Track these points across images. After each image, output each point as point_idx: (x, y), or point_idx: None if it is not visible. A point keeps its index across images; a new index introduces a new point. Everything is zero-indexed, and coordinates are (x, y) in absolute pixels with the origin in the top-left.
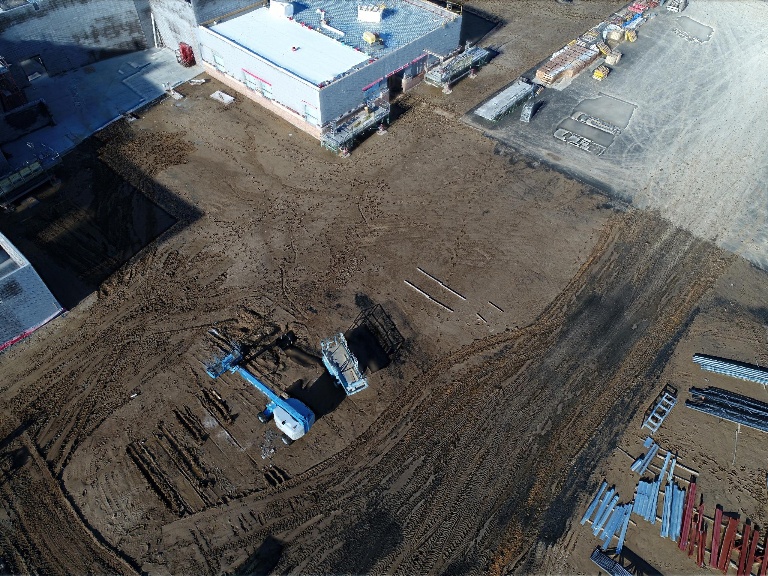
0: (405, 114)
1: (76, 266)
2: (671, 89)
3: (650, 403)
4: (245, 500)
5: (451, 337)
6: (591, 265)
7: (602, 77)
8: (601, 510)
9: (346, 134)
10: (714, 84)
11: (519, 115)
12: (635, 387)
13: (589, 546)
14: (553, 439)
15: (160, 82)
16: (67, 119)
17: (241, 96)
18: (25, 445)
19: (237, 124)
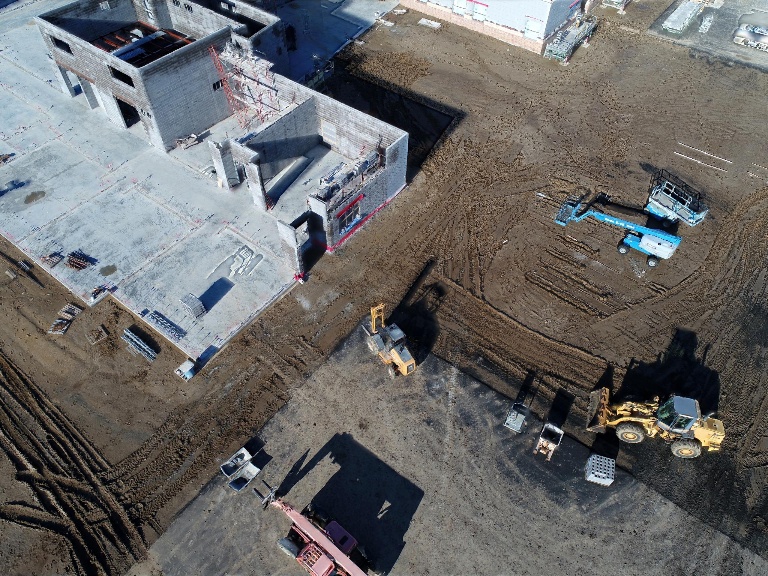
0: (597, 31)
1: None
2: None
3: None
4: (644, 305)
5: (736, 189)
6: None
7: None
8: None
9: None
10: None
11: (695, 28)
12: None
13: None
14: None
15: (366, 13)
16: (303, 45)
17: (445, 22)
18: (440, 279)
19: (456, 43)
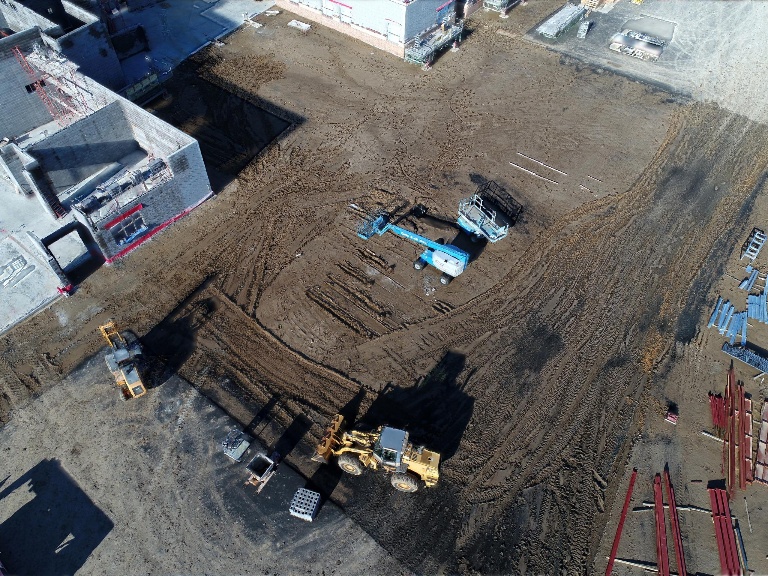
0: (471, 35)
1: (210, 161)
2: (703, 10)
3: (744, 241)
4: (422, 325)
5: (562, 202)
6: (668, 145)
7: (641, 1)
8: (723, 316)
9: (428, 48)
10: (740, 5)
11: (575, 33)
12: (728, 231)
13: (718, 342)
14: (669, 270)
15: (237, 14)
16: (159, 46)
17: (316, 24)
18: (214, 295)
19: (320, 46)
